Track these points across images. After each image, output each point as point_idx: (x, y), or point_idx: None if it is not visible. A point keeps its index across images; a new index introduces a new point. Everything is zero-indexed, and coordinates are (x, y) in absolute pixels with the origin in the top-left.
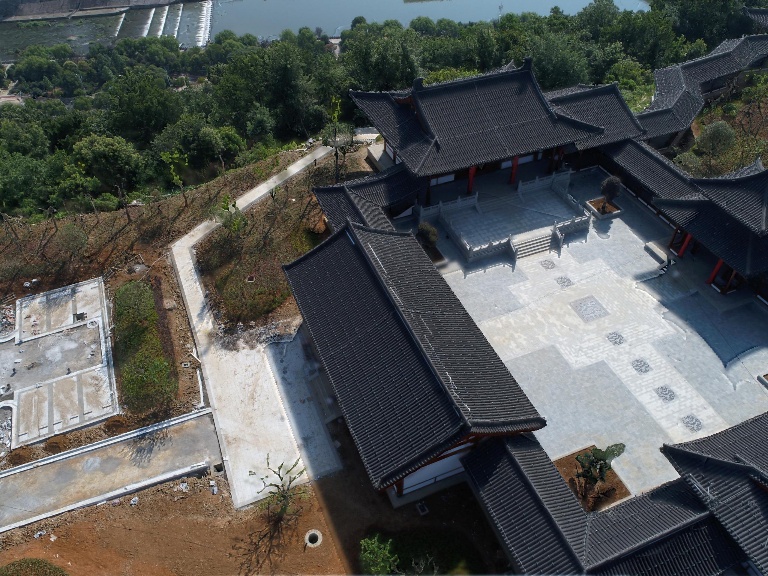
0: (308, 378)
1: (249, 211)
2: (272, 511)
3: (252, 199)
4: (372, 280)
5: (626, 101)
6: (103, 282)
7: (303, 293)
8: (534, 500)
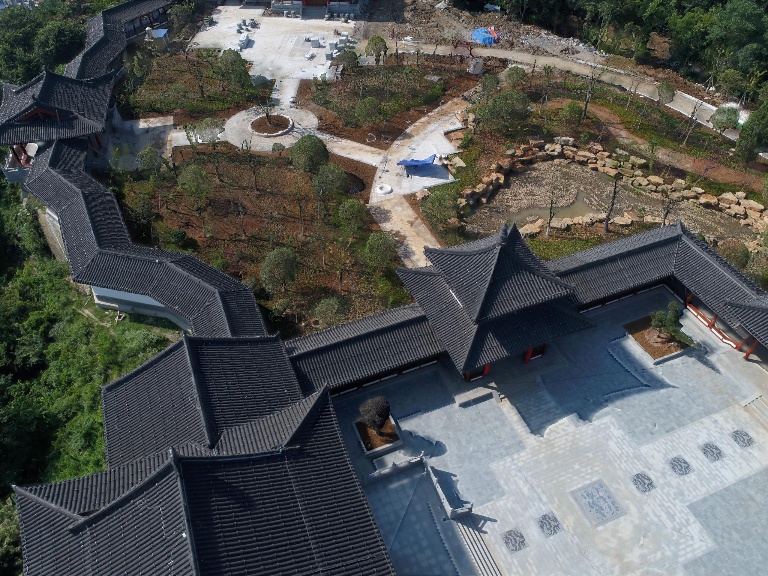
0: None
1: None
2: None
3: None
4: None
5: (92, 336)
6: None
7: None
8: None
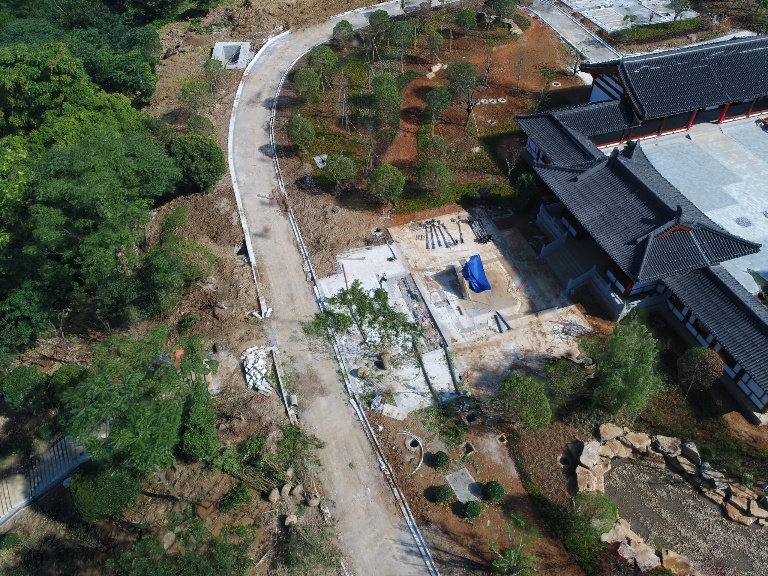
0: None
1: None
2: (567, 73)
3: None
4: None
5: None
6: (698, 16)
7: None
8: None
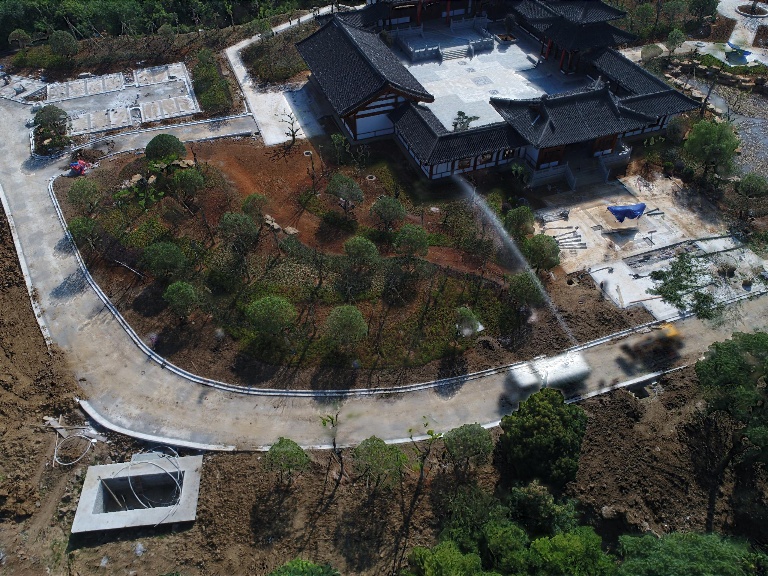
0: (308, 104)
1: (274, 36)
2: (286, 144)
3: (276, 31)
4: (346, 40)
5: None
6: (184, 64)
7: (307, 54)
8: (420, 121)
